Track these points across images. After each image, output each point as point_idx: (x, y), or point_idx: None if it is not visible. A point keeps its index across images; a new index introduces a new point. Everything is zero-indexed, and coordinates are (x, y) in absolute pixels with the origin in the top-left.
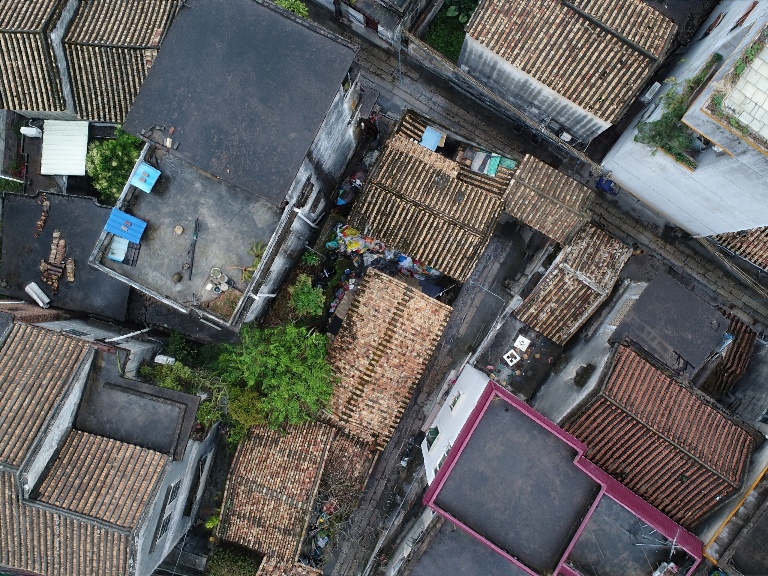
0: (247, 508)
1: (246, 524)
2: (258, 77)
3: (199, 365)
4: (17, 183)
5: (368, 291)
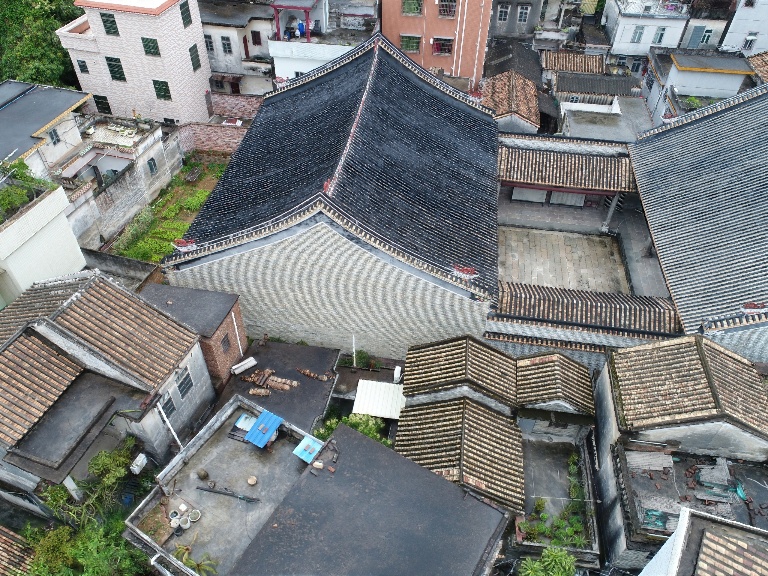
0: None
1: None
2: (381, 571)
3: (124, 499)
4: (361, 365)
5: None
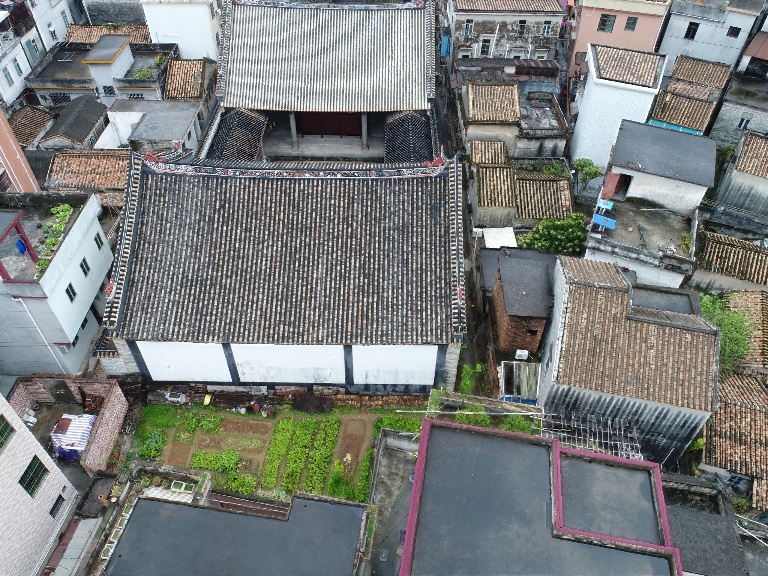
0: (727, 425)
1: (729, 444)
2: (672, 147)
3: None
4: None
5: (732, 300)
